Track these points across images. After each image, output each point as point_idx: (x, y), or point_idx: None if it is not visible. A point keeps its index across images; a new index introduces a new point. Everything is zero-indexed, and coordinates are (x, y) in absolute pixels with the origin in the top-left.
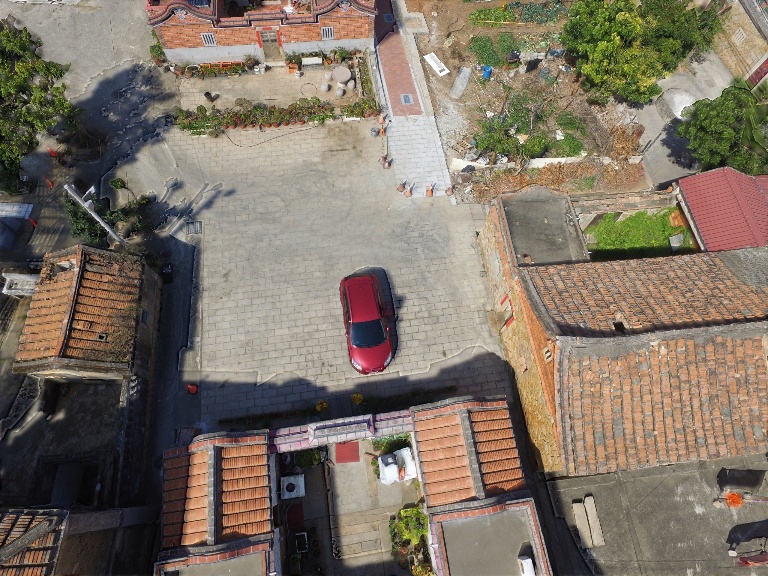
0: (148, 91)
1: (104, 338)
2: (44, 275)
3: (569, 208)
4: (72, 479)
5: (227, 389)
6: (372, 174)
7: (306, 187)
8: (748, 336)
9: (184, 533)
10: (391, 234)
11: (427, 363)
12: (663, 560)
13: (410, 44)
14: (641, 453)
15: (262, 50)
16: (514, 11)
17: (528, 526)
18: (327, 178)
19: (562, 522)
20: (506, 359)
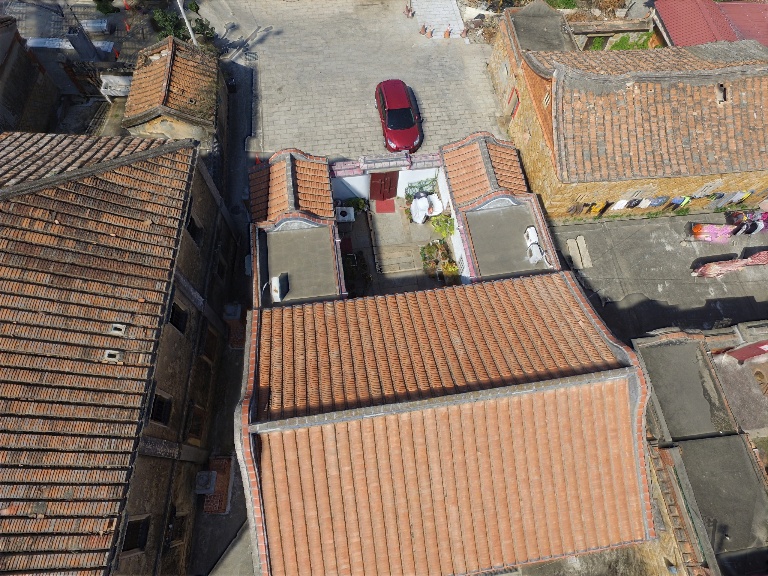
0: None
1: (194, 102)
2: (140, 64)
3: (564, 22)
4: None
5: None
6: (398, 22)
7: (343, 30)
8: (703, 84)
9: (269, 214)
10: (416, 63)
11: None
12: (639, 278)
13: None
14: (619, 168)
15: None
16: None
17: (532, 215)
18: (360, 24)
19: (558, 253)
20: None
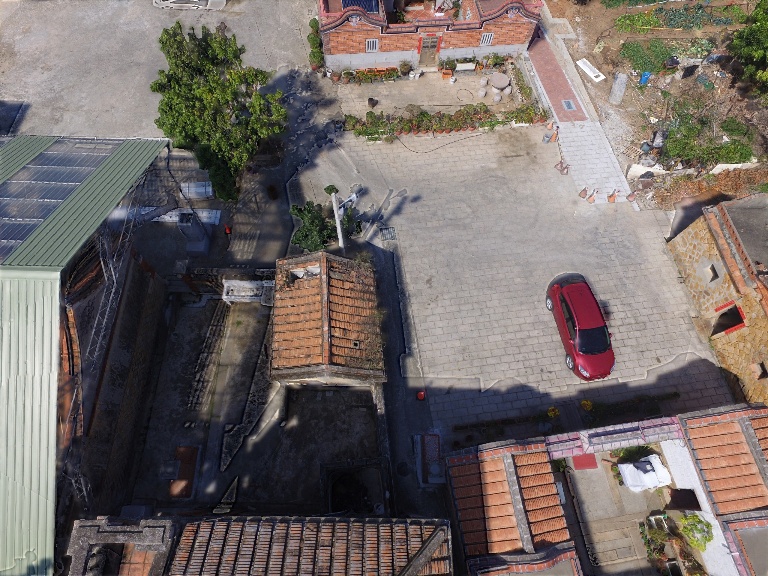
0: (310, 97)
1: (358, 345)
2: (281, 282)
3: None
4: (331, 486)
5: (453, 395)
6: (551, 180)
7: (489, 193)
8: None
9: (489, 541)
10: (582, 240)
11: (644, 369)
12: None
13: (561, 50)
14: None
15: (419, 56)
16: (657, 17)
17: None
18: (508, 184)
19: None
20: (721, 366)
